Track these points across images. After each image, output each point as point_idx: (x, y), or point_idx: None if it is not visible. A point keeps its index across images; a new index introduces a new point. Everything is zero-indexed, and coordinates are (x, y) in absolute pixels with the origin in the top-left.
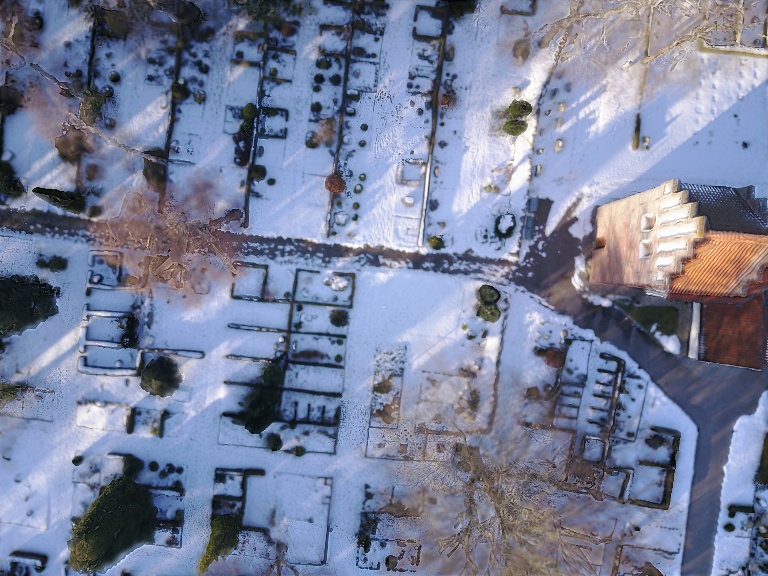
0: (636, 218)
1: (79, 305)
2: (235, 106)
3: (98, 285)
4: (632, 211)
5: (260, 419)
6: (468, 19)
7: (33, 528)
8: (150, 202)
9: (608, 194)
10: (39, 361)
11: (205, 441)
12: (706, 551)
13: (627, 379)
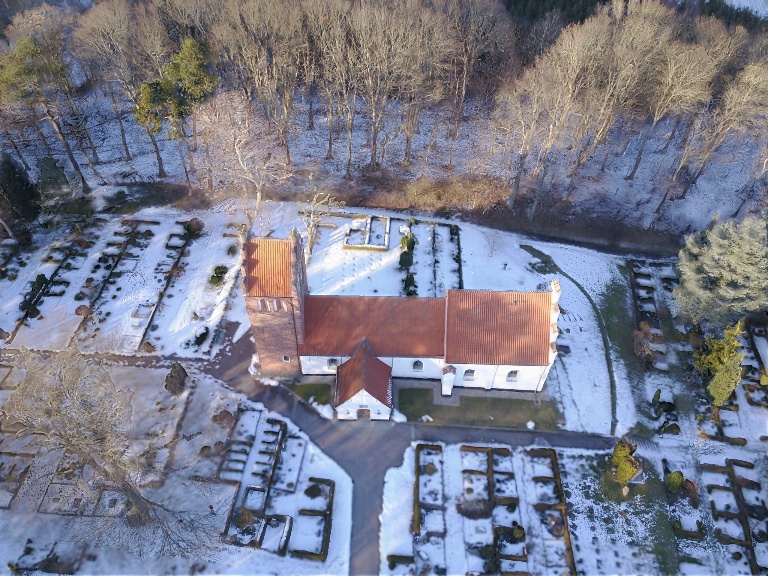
0: None
1: None
2: (34, 281)
3: None
4: None
5: None
6: (202, 240)
7: None
8: None
9: None
10: None
11: None
12: None
13: (289, 439)
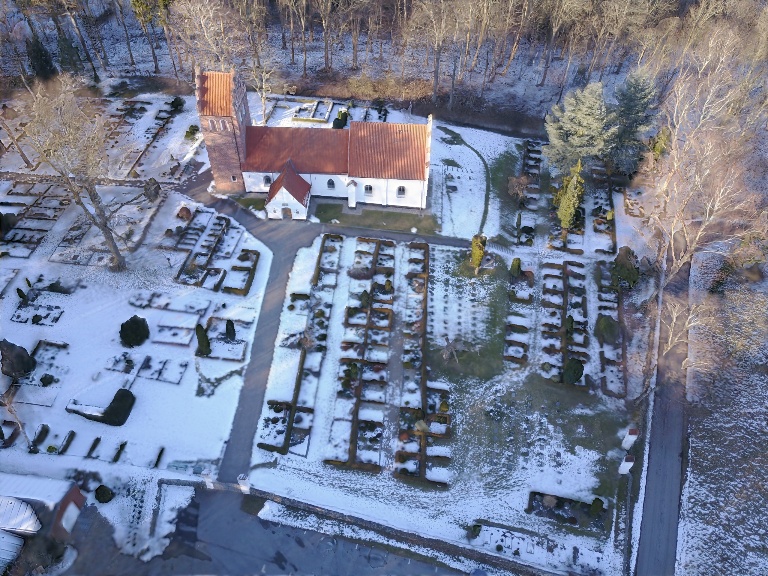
0: None
1: None
2: None
3: None
4: None
5: None
6: (184, 114)
7: None
8: None
9: None
10: None
11: None
12: (274, 323)
13: (231, 229)
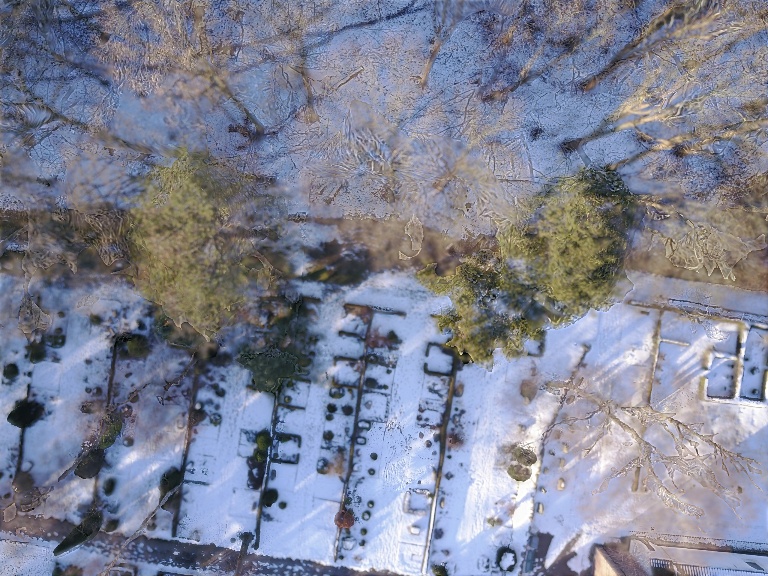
0: None
1: None
2: (250, 430)
3: None
4: None
5: None
6: None
7: None
8: (164, 519)
9: (606, 532)
10: None
11: None
12: None
13: None
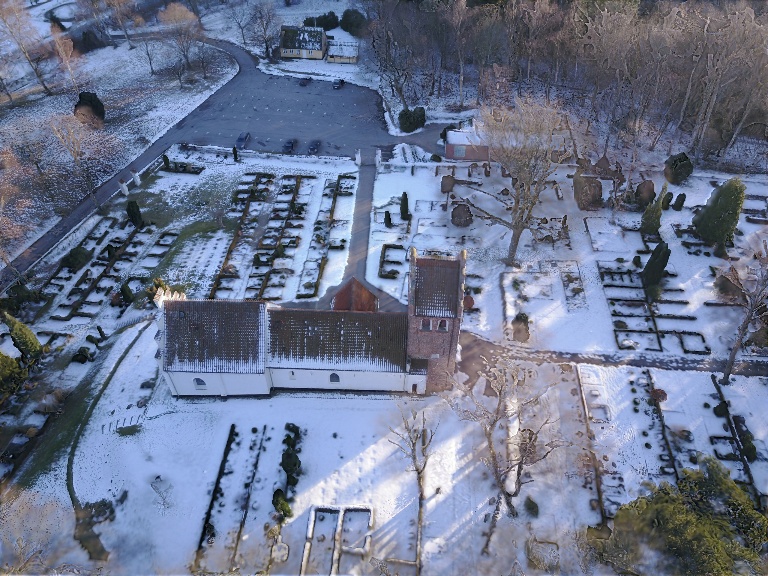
0: None
1: None
2: (764, 462)
3: None
4: None
5: None
6: None
7: (764, 232)
8: None
9: None
10: None
11: (681, 265)
12: None
13: None
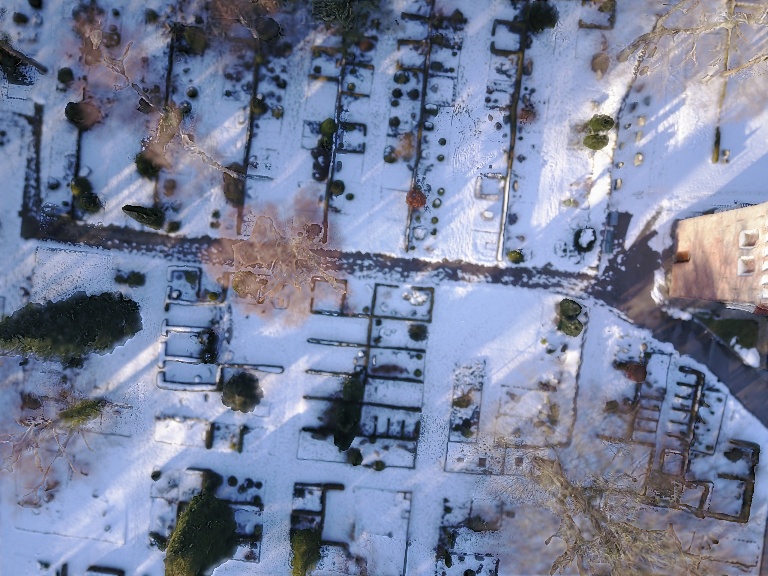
0: (732, 234)
1: (157, 320)
2: (313, 121)
3: (177, 300)
4: (727, 227)
5: (347, 435)
6: (546, 33)
7: (110, 543)
8: (228, 217)
9: (688, 207)
10: (117, 376)
11: (284, 456)
12: None
13: (706, 392)
